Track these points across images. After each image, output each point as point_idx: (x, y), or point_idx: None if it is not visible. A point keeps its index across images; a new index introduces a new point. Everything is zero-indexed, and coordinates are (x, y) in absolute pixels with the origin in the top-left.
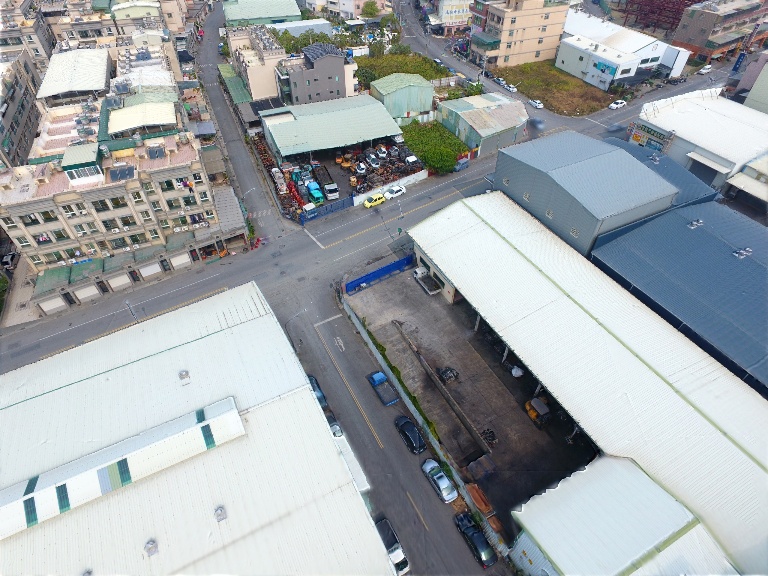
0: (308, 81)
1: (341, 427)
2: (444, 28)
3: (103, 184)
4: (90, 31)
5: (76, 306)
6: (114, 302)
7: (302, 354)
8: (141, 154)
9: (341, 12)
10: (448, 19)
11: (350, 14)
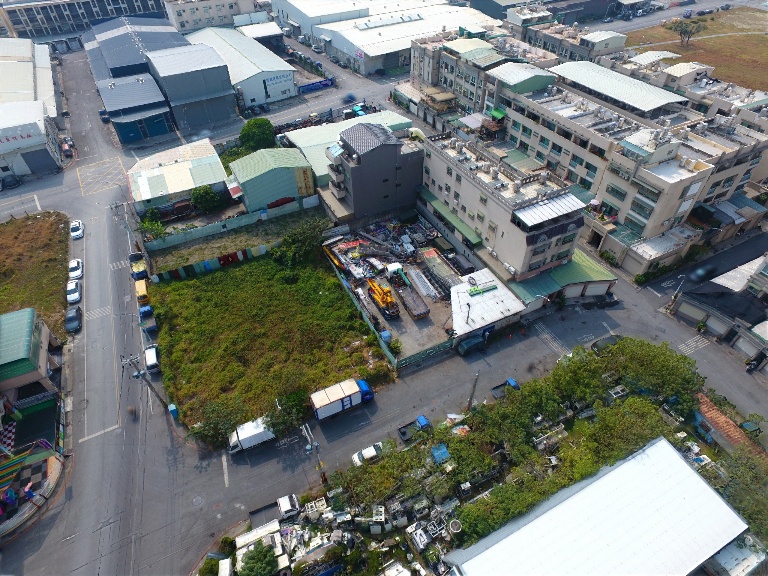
0: None
1: (332, 62)
2: None
3: None
4: None
5: None
6: None
7: (350, 72)
8: None
9: None
10: None
11: None
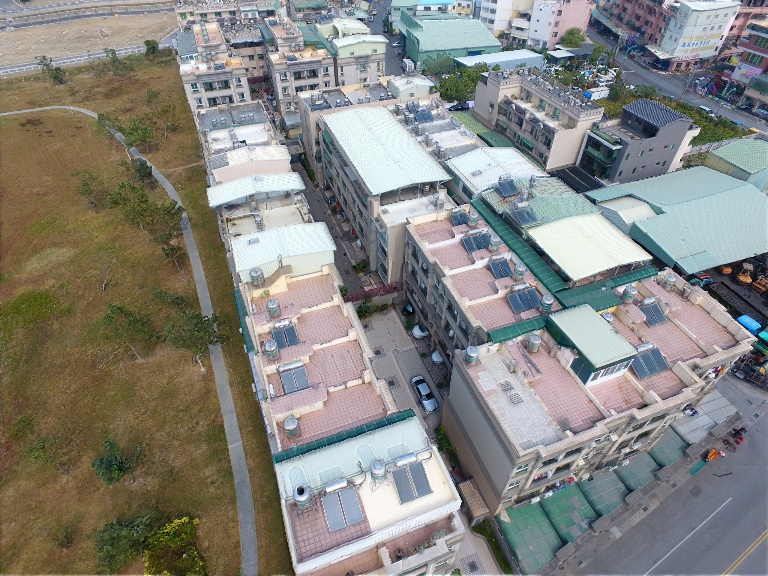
0: (642, 151)
1: None
2: (672, 63)
3: (644, 390)
4: (306, 72)
5: (557, 570)
6: (611, 561)
7: None
8: (643, 320)
9: (529, 39)
10: (682, 53)
11: (542, 42)
